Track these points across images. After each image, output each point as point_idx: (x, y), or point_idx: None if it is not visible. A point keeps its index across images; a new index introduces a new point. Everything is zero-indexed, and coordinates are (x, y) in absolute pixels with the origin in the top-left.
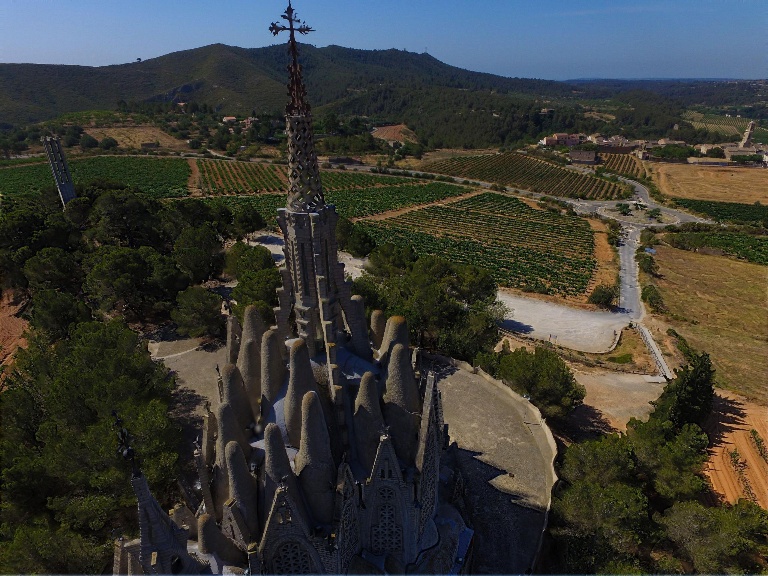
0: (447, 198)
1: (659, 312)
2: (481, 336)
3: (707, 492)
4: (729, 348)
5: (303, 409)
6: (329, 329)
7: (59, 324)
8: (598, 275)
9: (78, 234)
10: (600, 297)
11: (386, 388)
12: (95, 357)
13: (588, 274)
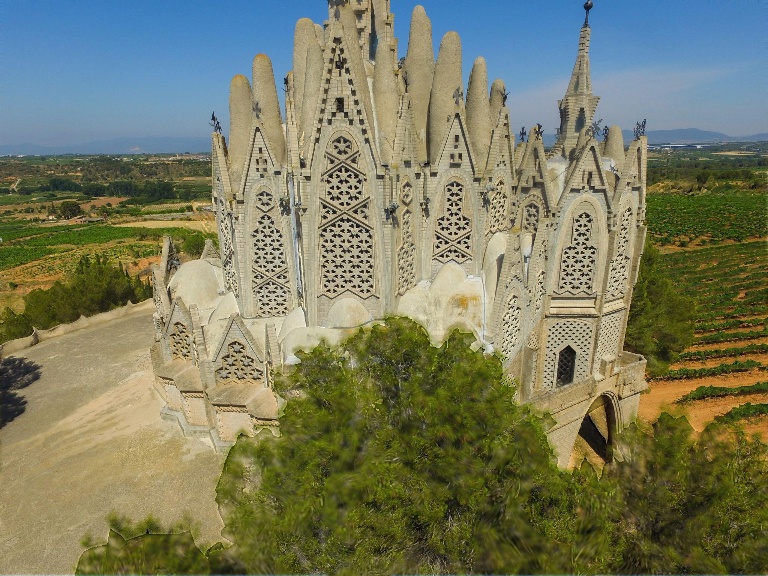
0: None
1: None
2: None
3: None
4: None
5: None
6: None
7: None
8: None
9: None
10: None
11: None
12: None
13: None
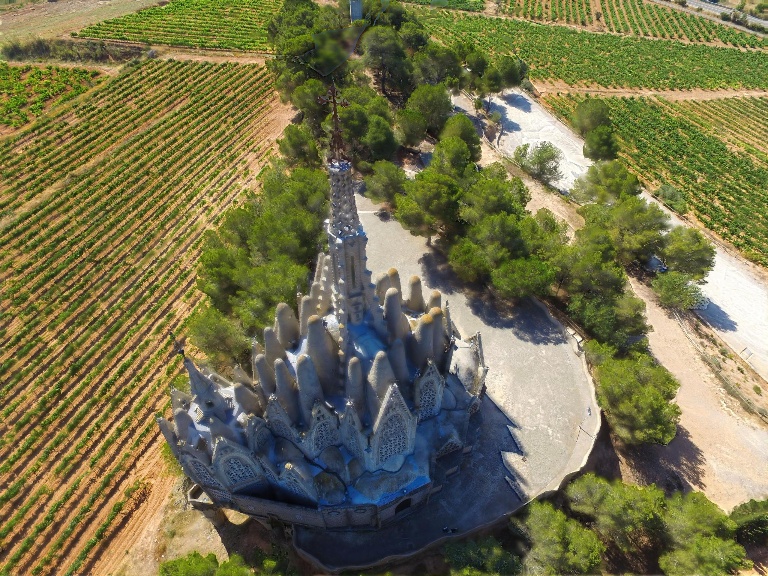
0: None
1: None
2: (622, 320)
3: None
4: None
5: None
6: (342, 316)
7: (297, 154)
8: None
9: (345, 63)
10: None
11: (370, 372)
12: (293, 204)
13: None
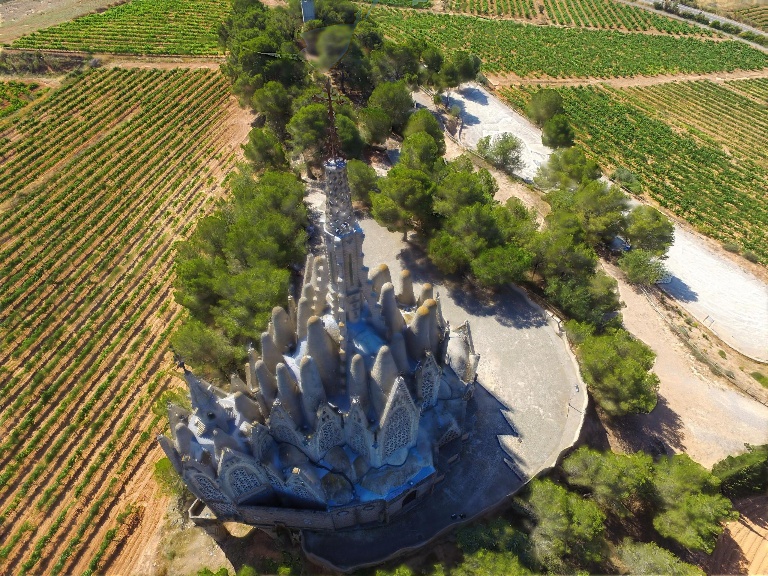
0: (736, 70)
1: None
2: (597, 299)
3: None
4: None
5: (300, 365)
6: (341, 314)
7: (263, 158)
8: None
9: (302, 64)
10: None
11: (373, 368)
12: (266, 208)
13: None
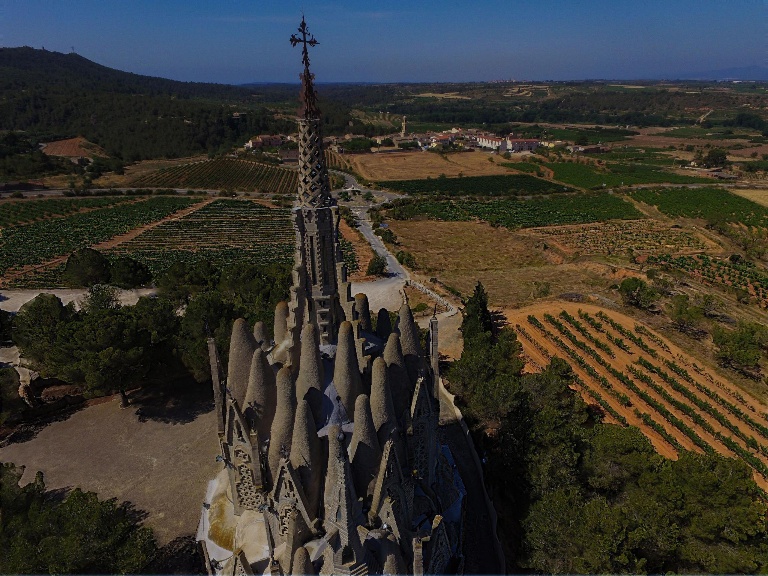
0: (178, 211)
1: (417, 269)
2: None
3: (523, 368)
4: (469, 281)
5: (380, 373)
6: None
7: None
8: (358, 253)
9: None
10: (376, 268)
11: None
12: None
13: (352, 253)
